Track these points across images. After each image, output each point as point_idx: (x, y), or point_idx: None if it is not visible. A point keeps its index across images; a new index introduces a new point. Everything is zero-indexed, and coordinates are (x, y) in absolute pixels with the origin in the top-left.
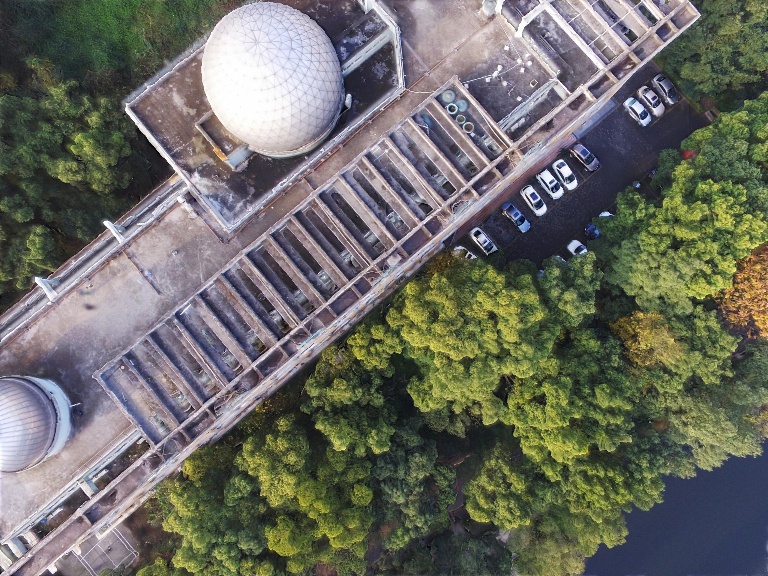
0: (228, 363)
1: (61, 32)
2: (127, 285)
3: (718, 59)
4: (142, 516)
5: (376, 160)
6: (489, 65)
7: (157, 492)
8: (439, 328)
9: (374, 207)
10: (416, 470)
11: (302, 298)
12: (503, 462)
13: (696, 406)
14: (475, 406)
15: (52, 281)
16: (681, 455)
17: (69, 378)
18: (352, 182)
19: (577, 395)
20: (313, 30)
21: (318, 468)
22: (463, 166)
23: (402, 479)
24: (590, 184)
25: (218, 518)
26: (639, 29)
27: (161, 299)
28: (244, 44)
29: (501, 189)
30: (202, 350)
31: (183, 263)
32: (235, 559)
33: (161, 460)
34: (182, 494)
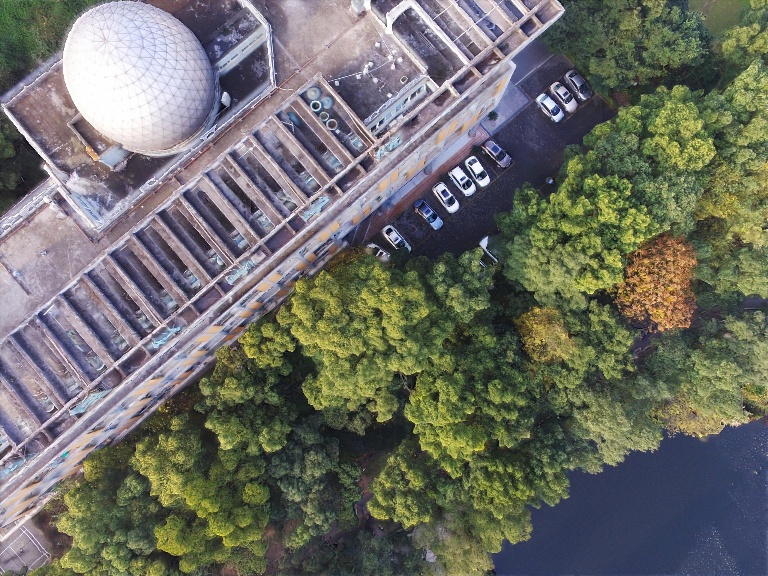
0: (93, 363)
1: None
2: None
3: (623, 54)
4: None
5: (241, 158)
6: (360, 62)
7: (59, 493)
8: (323, 326)
9: (239, 205)
10: (311, 468)
11: (167, 297)
12: (401, 459)
13: (596, 401)
14: (371, 403)
15: None
16: (587, 450)
17: None
18: (217, 180)
19: (473, 391)
20: (170, 28)
21: (211, 467)
22: (328, 163)
23: (299, 477)
24: (503, 180)
25: (108, 518)
26: (505, 24)
27: (30, 300)
28: (93, 43)
29: (397, 186)
30: (64, 350)
31: (53, 263)
32: (125, 559)
33: (23, 461)
34: (75, 495)
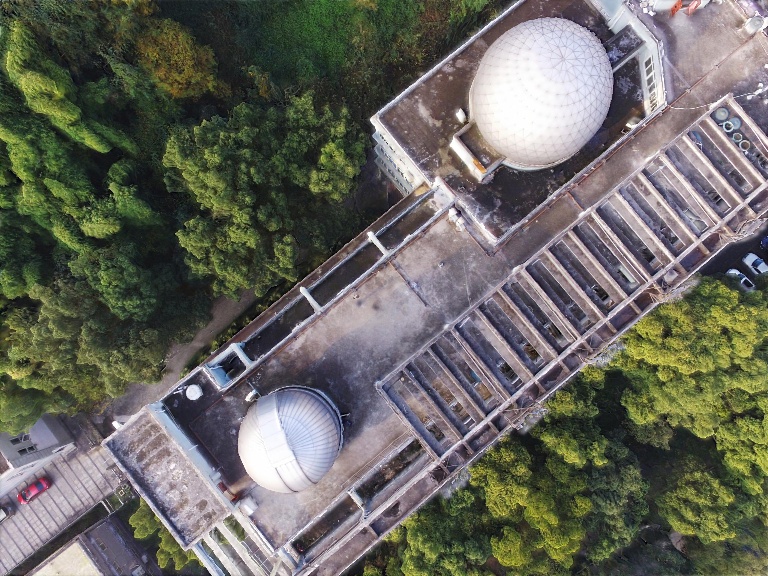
0: None
1: (266, 39)
2: (394, 296)
3: None
4: None
5: (651, 176)
6: (749, 83)
7: None
8: (676, 342)
9: (649, 223)
10: (630, 482)
11: (577, 312)
12: (709, 475)
13: None
14: (687, 419)
15: (308, 290)
16: None
17: (337, 388)
18: (627, 198)
19: None
20: (602, 46)
21: (538, 479)
22: (736, 184)
23: (613, 491)
24: None
25: (443, 528)
26: None
27: (428, 311)
28: (550, 60)
29: None
30: (483, 363)
31: (449, 275)
32: (462, 569)
33: (443, 472)
34: None
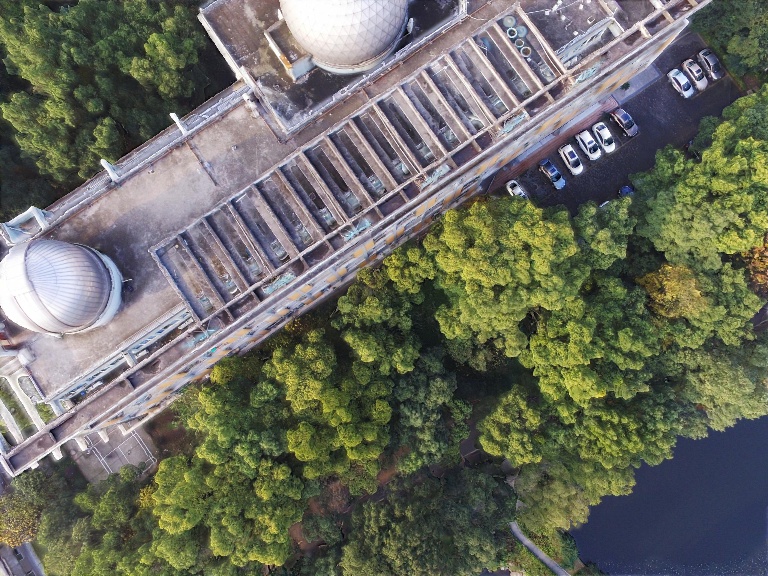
0: (276, 253)
1: None
2: (186, 174)
3: (766, 35)
4: (163, 425)
5: (435, 75)
6: None
7: (184, 395)
8: (475, 252)
9: (428, 119)
10: (436, 394)
11: (352, 199)
12: (521, 398)
13: (715, 365)
14: (499, 339)
15: (115, 167)
16: (694, 415)
17: (124, 255)
18: (410, 94)
19: None
20: None
21: (343, 381)
22: (517, 88)
23: (422, 403)
24: (627, 149)
25: (243, 417)
26: None
27: (217, 190)
28: None
29: (544, 135)
30: (253, 236)
31: (241, 158)
32: (256, 457)
33: None
34: (211, 392)
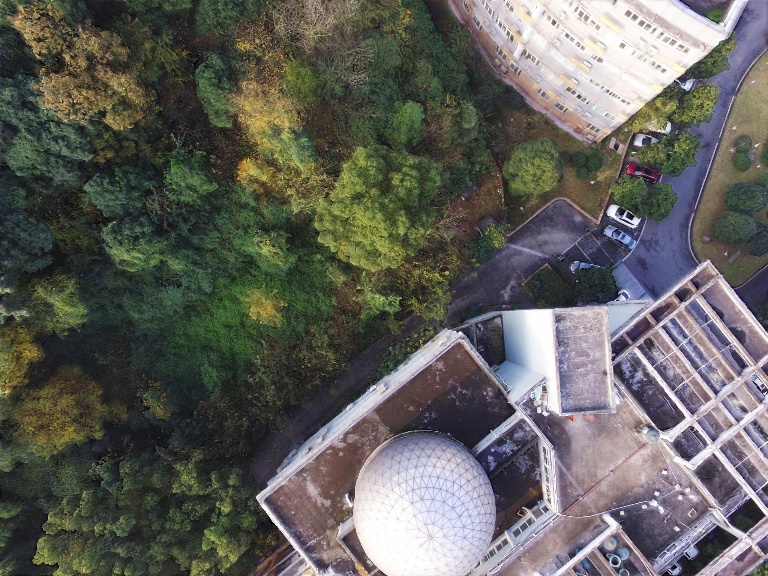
0: None
1: (168, 345)
2: None
3: None
4: None
5: None
6: (645, 489)
7: None
8: None
9: None
10: None
11: None
12: None
13: None
14: None
15: None
16: None
17: None
18: None
19: None
20: (480, 496)
21: None
22: None
23: None
24: None
25: None
26: None
27: None
28: (417, 539)
29: None
30: None
31: None
32: None
33: None
34: None
